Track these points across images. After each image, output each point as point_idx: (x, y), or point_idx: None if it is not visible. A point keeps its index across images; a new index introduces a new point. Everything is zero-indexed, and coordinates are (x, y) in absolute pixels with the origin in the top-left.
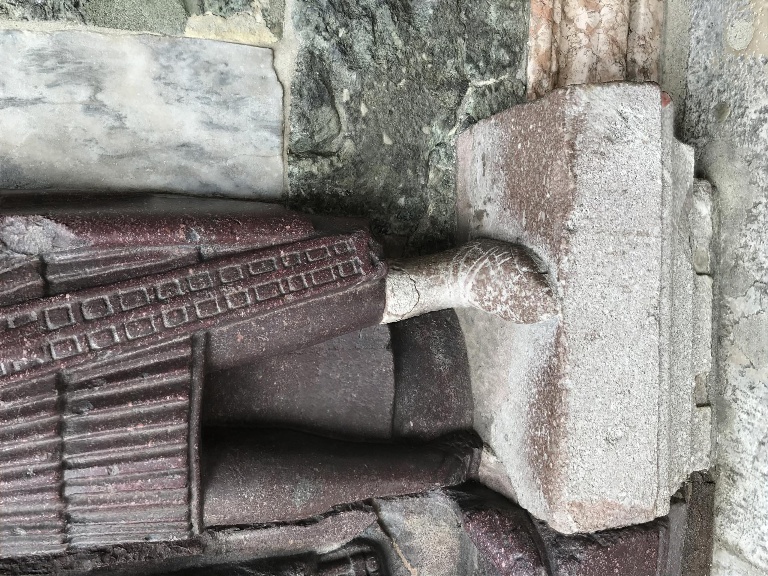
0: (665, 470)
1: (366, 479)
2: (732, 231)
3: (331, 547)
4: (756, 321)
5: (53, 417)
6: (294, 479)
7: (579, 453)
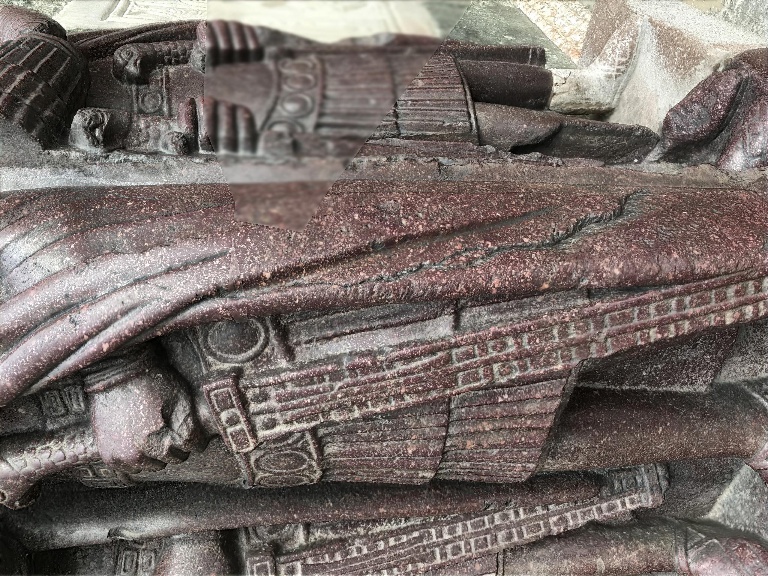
0: None
1: None
2: None
3: None
4: None
5: None
6: None
7: None
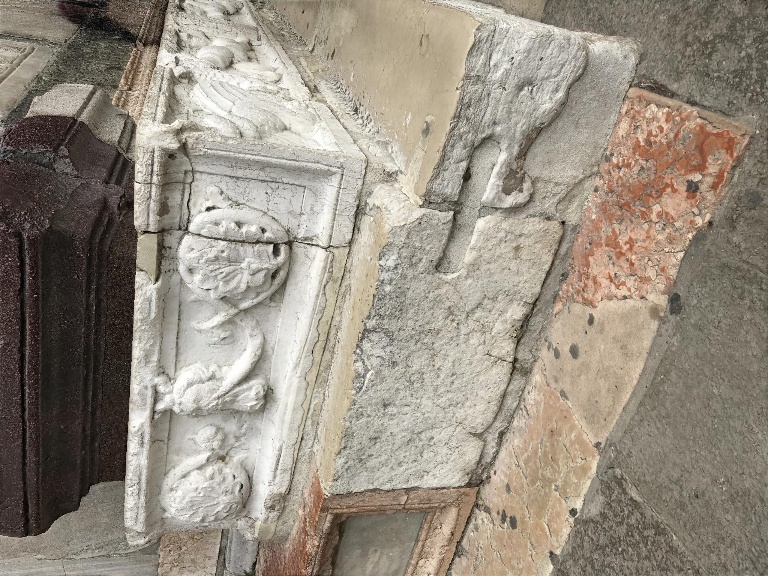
0: None
1: None
2: None
3: None
4: None
5: None
6: None
7: None
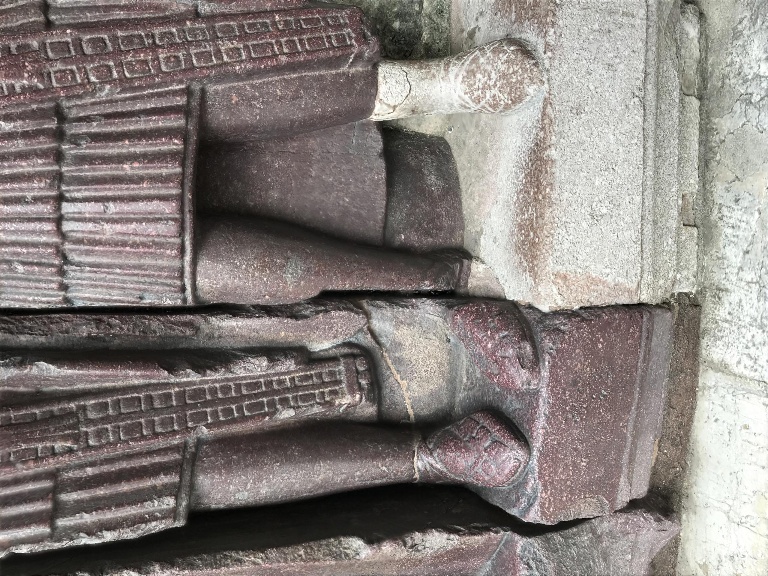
0: (649, 255)
1: (356, 267)
2: (719, 53)
3: (322, 345)
4: (741, 134)
5: (52, 145)
6: (286, 255)
7: (564, 224)
